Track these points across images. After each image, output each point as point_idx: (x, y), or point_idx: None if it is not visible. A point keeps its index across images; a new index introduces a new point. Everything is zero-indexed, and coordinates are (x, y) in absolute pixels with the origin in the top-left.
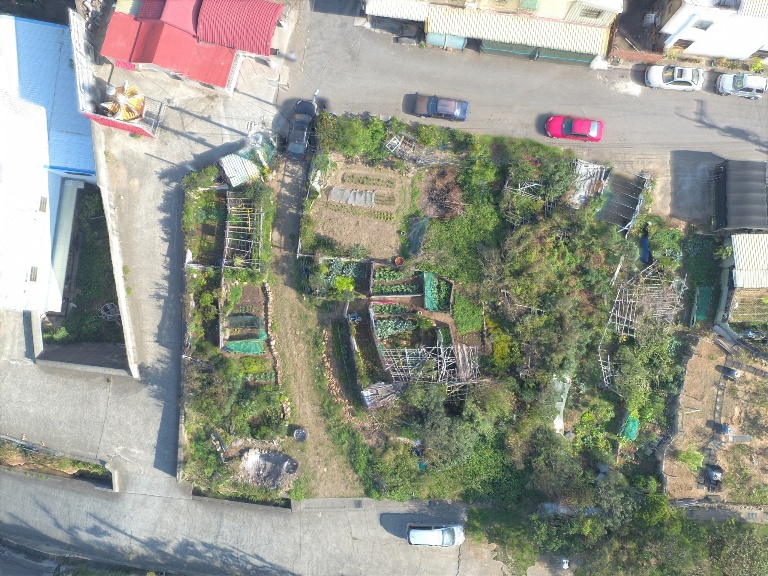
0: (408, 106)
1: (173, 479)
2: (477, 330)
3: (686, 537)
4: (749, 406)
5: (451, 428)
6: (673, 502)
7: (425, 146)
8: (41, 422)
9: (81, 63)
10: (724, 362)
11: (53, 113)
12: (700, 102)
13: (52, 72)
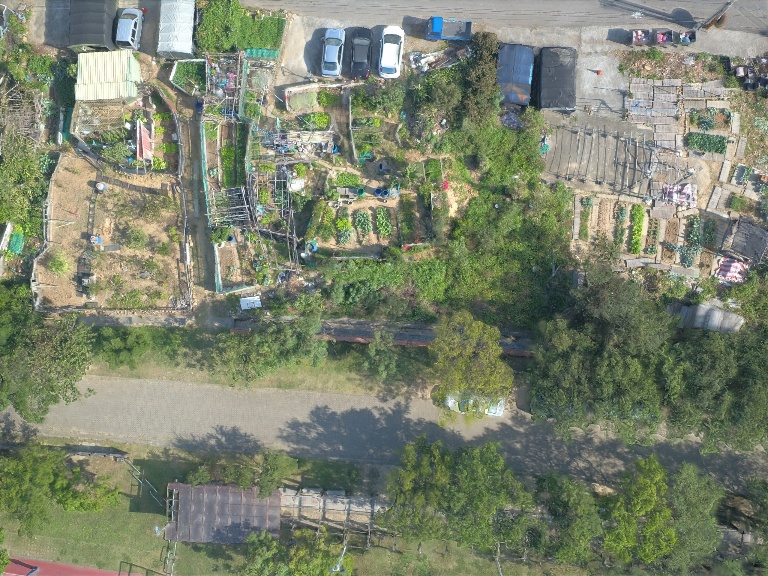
0: None
1: None
2: None
3: (11, 326)
4: (118, 217)
5: None
6: (52, 309)
7: None
8: None
9: None
10: (95, 177)
11: None
12: None
13: None
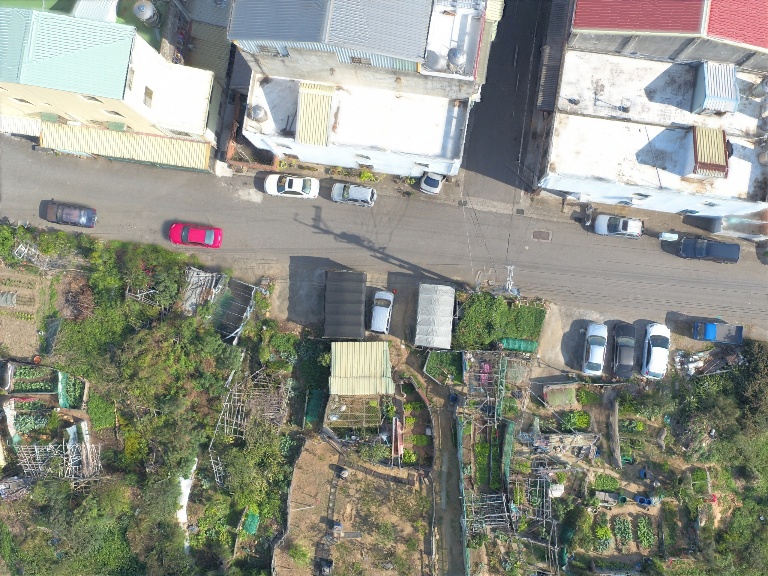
0: (44, 212)
1: None
2: (111, 426)
3: None
4: (360, 503)
5: (71, 523)
6: None
7: (48, 254)
8: None
9: None
10: (337, 461)
11: None
12: (319, 209)
13: None
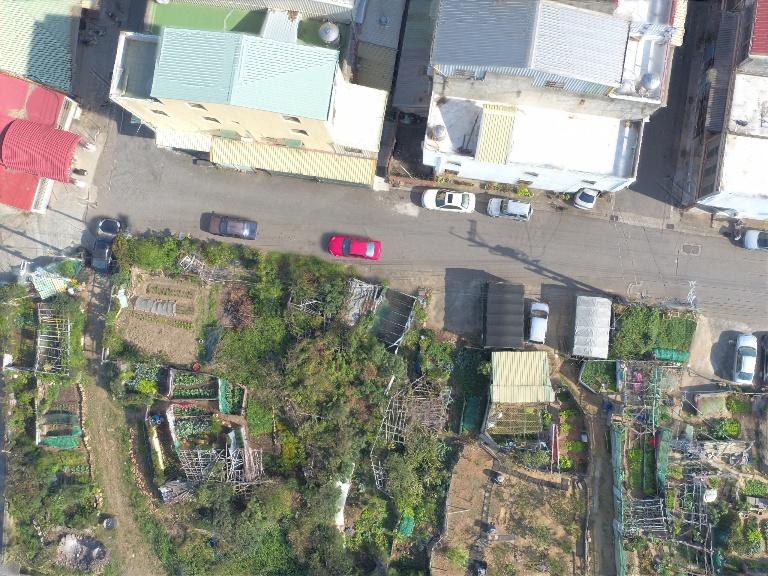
0: (205, 224)
1: None
2: (268, 432)
3: None
4: (514, 507)
5: (235, 525)
6: None
7: (214, 265)
8: None
9: None
10: (491, 466)
11: None
12: (474, 223)
13: None
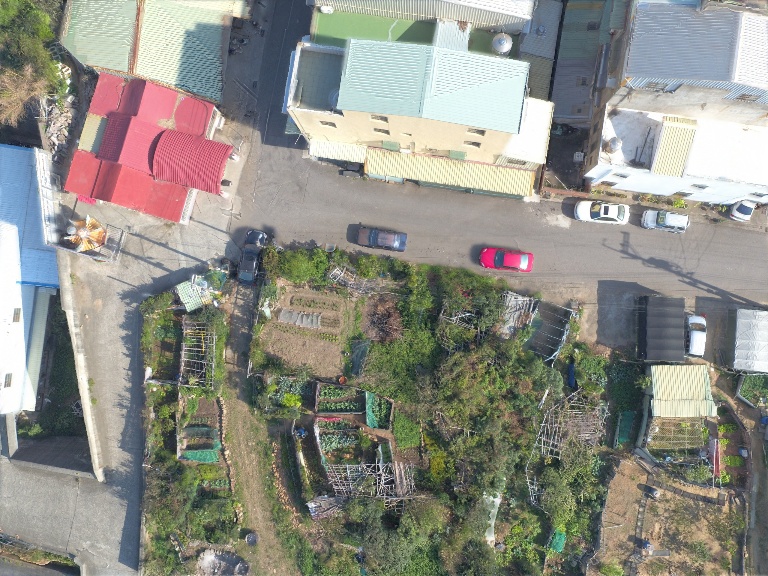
0: (352, 235)
1: (136, 573)
2: (415, 446)
3: None
4: (668, 522)
5: (388, 541)
6: None
7: (365, 278)
8: (16, 516)
9: (47, 197)
10: (645, 481)
11: (25, 232)
12: (627, 234)
13: (24, 193)
